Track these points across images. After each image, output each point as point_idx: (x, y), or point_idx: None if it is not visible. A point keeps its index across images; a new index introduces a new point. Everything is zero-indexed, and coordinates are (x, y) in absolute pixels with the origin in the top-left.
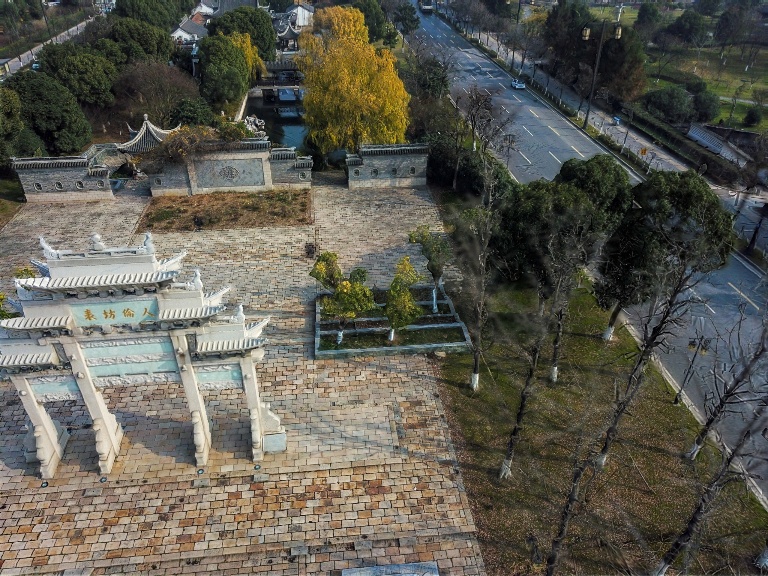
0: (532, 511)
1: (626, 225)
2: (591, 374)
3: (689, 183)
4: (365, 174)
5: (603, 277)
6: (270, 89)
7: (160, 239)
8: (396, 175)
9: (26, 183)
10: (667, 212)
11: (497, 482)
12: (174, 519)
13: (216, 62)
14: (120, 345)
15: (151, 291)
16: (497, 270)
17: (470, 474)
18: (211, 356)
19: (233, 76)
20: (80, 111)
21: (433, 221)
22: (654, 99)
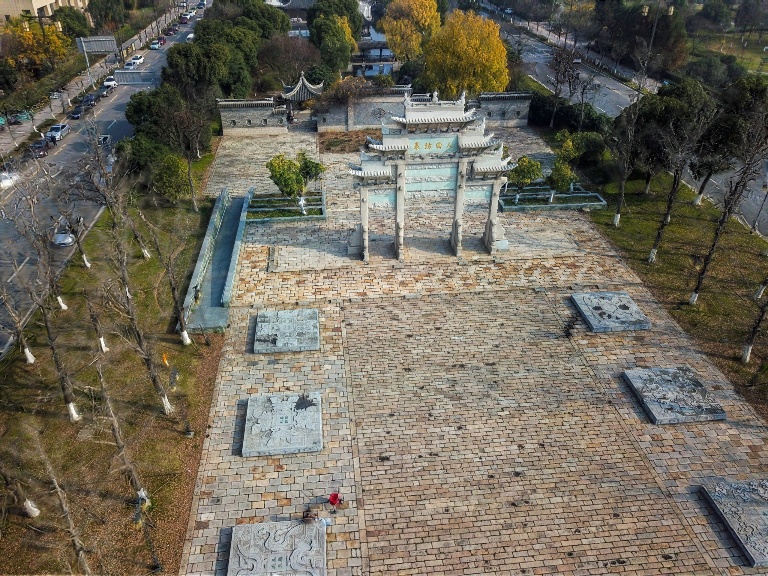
0: (674, 275)
1: (717, 116)
2: (691, 220)
3: (762, 83)
4: (481, 116)
5: (696, 158)
6: (359, 65)
7: (341, 157)
8: (505, 117)
9: (225, 120)
10: (749, 101)
11: (648, 264)
12: (456, 277)
13: (327, 38)
14: (427, 168)
15: (455, 131)
16: (622, 155)
17: (629, 261)
18: (477, 179)
19: (345, 49)
20: (246, 70)
21: (542, 147)
22: (695, 67)
